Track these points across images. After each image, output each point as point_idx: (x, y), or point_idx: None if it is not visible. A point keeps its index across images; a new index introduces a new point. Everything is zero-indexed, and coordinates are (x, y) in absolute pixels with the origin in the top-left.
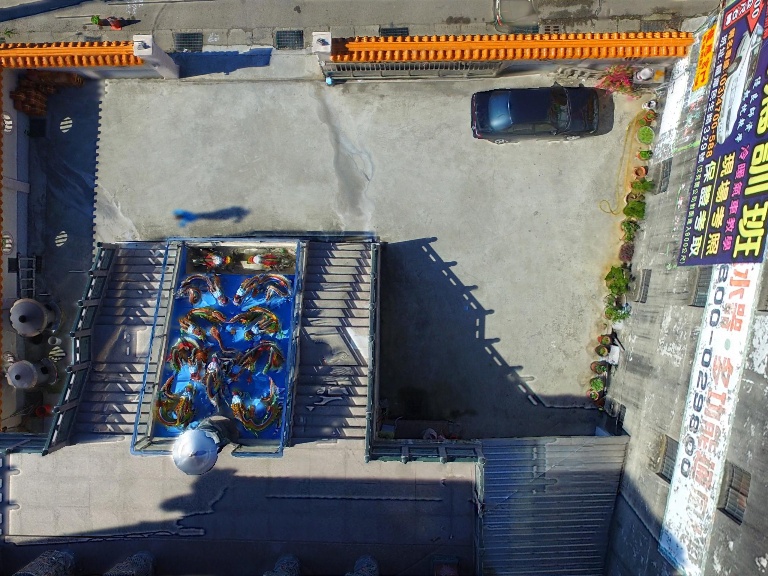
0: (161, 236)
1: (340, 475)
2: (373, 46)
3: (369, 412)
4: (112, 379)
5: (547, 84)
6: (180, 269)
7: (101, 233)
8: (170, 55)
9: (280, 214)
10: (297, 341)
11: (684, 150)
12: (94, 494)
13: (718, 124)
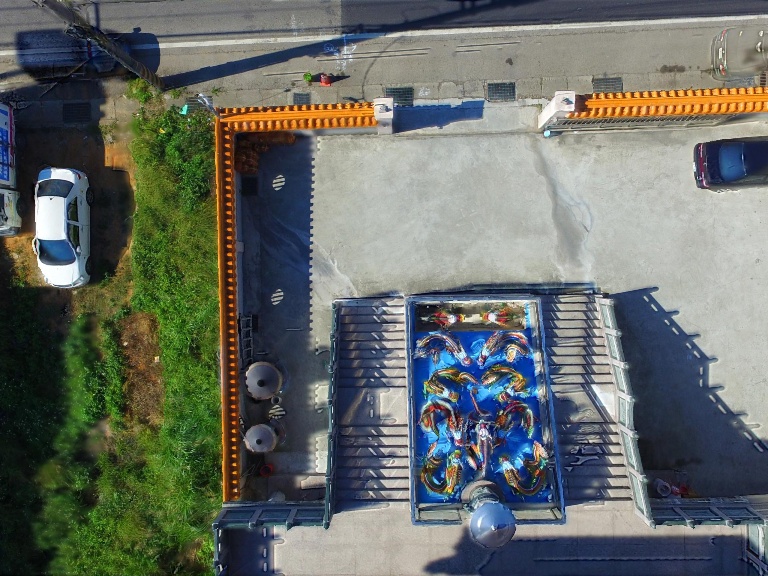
0: (379, 292)
1: (608, 537)
2: (612, 103)
3: (644, 475)
4: (361, 443)
5: (766, 131)
6: (412, 328)
7: (318, 290)
8: None
9: (499, 267)
10: (545, 400)
11: None
12: (360, 561)
13: None
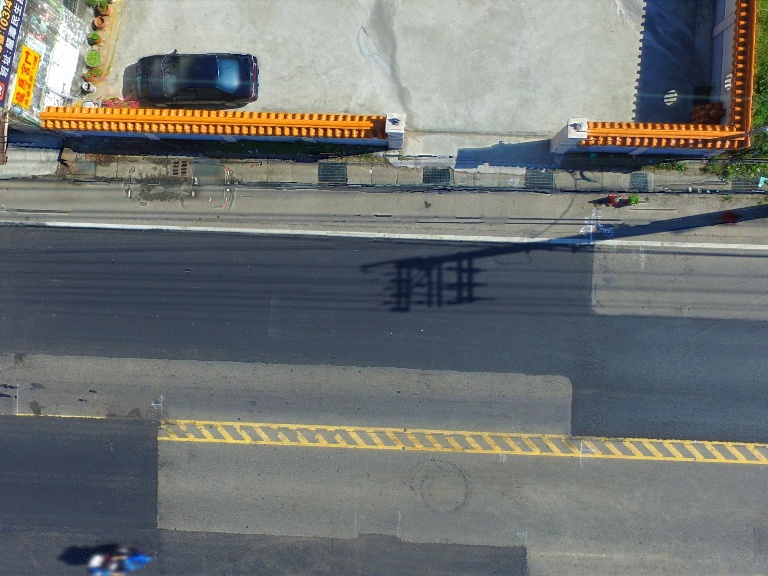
0: None
1: None
2: (347, 124)
3: None
4: None
5: None
6: None
7: None
8: (560, 166)
9: None
10: None
11: None
12: None
13: None
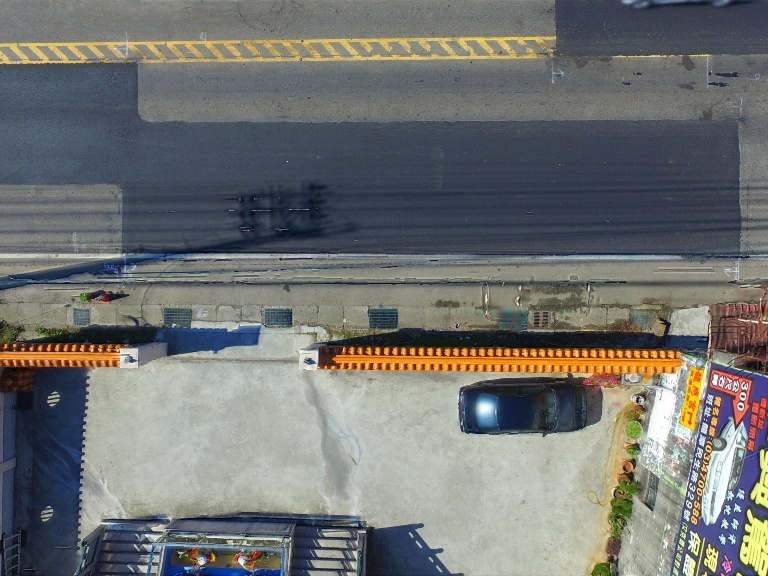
0: (147, 514)
1: None
2: (360, 359)
3: None
4: None
5: None
6: (165, 565)
7: (87, 510)
8: (158, 330)
9: (267, 496)
10: None
11: (670, 485)
12: None
13: (703, 495)
